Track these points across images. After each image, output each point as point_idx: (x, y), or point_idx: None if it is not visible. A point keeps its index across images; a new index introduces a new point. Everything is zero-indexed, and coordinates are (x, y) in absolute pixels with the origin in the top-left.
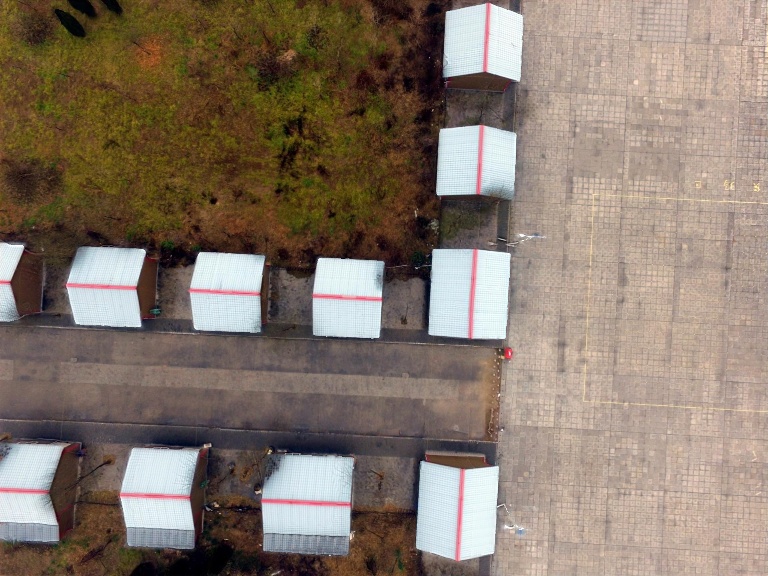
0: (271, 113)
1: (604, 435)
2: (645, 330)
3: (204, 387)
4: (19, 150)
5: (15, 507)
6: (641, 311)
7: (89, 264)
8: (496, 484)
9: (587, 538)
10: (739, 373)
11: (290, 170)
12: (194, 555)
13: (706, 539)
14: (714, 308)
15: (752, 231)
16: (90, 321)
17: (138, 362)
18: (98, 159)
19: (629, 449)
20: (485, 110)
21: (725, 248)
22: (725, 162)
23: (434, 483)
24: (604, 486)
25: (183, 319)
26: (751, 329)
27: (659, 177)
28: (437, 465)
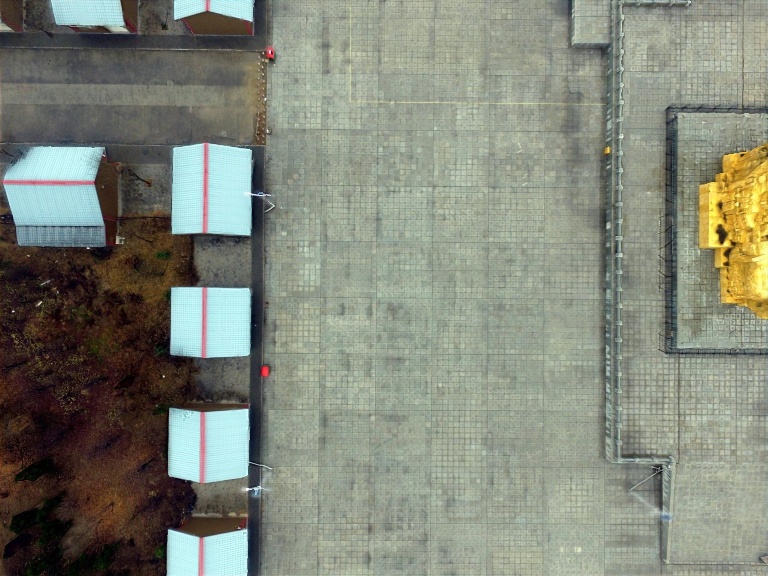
0: None
1: (372, 134)
2: (408, 28)
3: None
4: None
5: None
6: (403, 9)
7: None
8: (249, 167)
9: (358, 236)
10: (502, 67)
11: None
12: None
13: (475, 231)
14: (475, 3)
15: None
16: None
17: None
18: None
19: (397, 147)
20: None
21: None
22: None
23: (184, 165)
24: (374, 185)
25: None
26: (512, 23)
27: None
28: (186, 147)
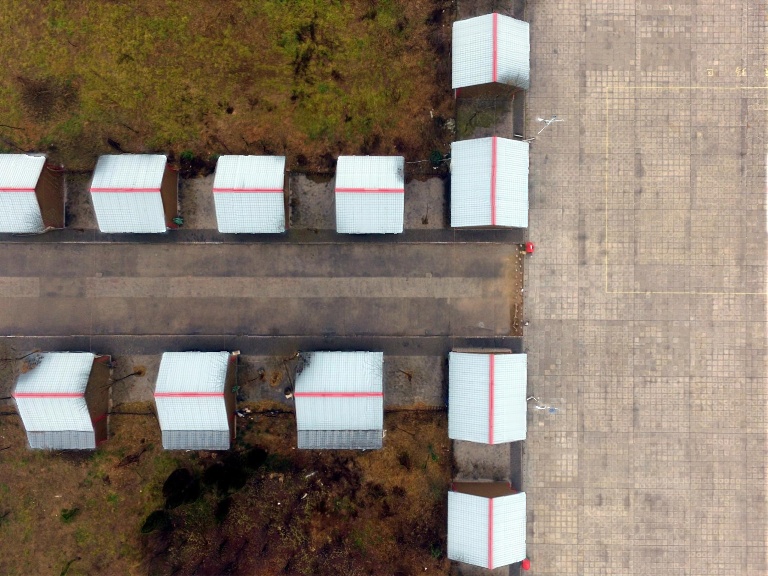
0: (283, 20)
1: (628, 325)
2: (664, 219)
3: (230, 296)
4: (33, 68)
5: (50, 414)
6: (659, 200)
7: (111, 170)
8: (525, 371)
9: (615, 427)
10: (758, 257)
11: (304, 76)
12: (228, 460)
13: (733, 422)
14: (731, 194)
15: (765, 116)
16: (115, 228)
17: (163, 274)
18: (113, 74)
19: (653, 337)
20: (496, 8)
21: (739, 134)
22: (736, 49)
23: (464, 372)
24: (630, 375)
25: (206, 229)
26: None
27: (671, 67)
28: (466, 354)
